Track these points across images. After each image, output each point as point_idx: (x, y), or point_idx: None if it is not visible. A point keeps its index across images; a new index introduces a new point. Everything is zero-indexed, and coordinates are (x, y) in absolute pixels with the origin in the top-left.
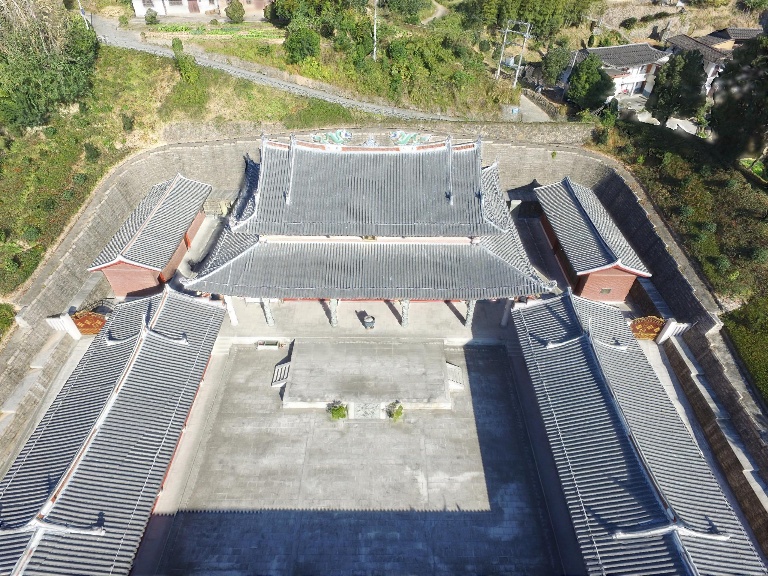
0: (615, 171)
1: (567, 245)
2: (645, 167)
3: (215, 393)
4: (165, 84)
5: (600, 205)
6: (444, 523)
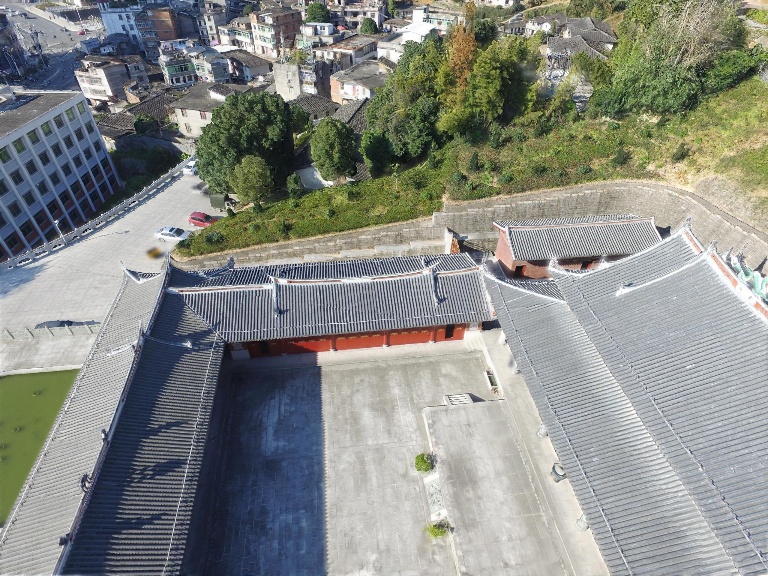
0: None
1: None
2: None
3: (424, 355)
4: (764, 139)
5: None
6: None
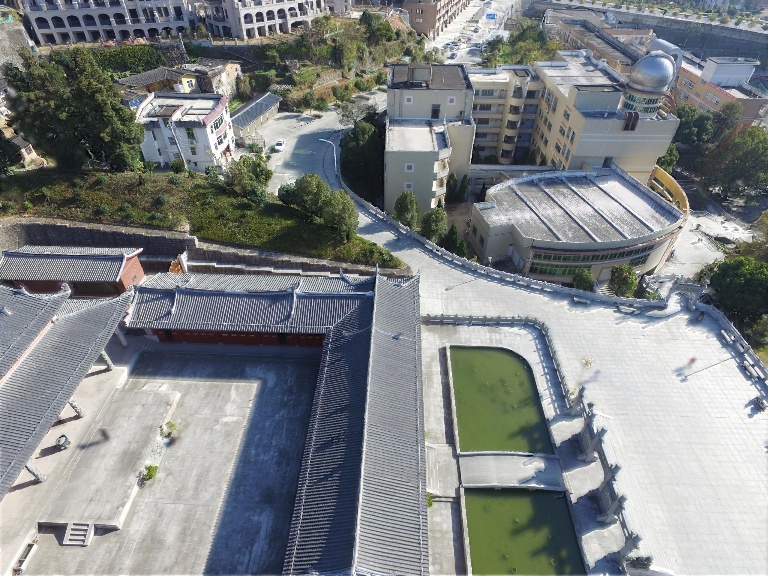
0: (22, 223)
1: (84, 278)
2: (37, 207)
3: None
4: None
5: (51, 247)
6: (258, 409)
